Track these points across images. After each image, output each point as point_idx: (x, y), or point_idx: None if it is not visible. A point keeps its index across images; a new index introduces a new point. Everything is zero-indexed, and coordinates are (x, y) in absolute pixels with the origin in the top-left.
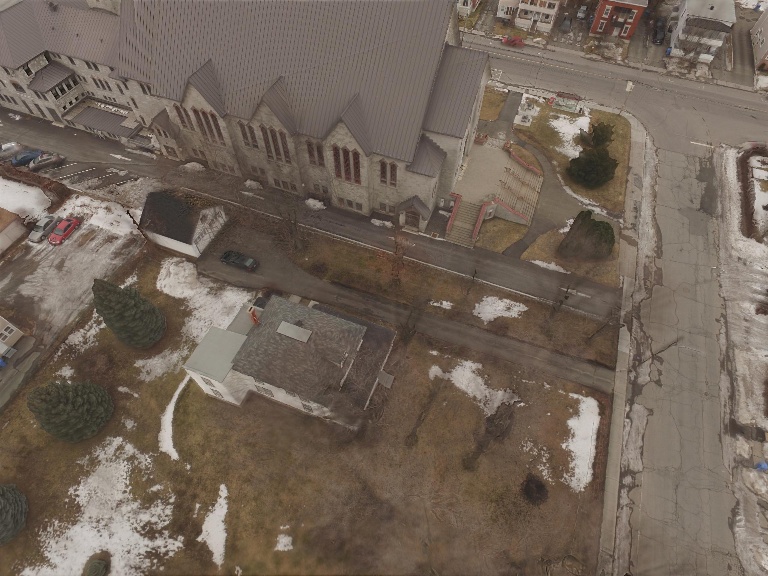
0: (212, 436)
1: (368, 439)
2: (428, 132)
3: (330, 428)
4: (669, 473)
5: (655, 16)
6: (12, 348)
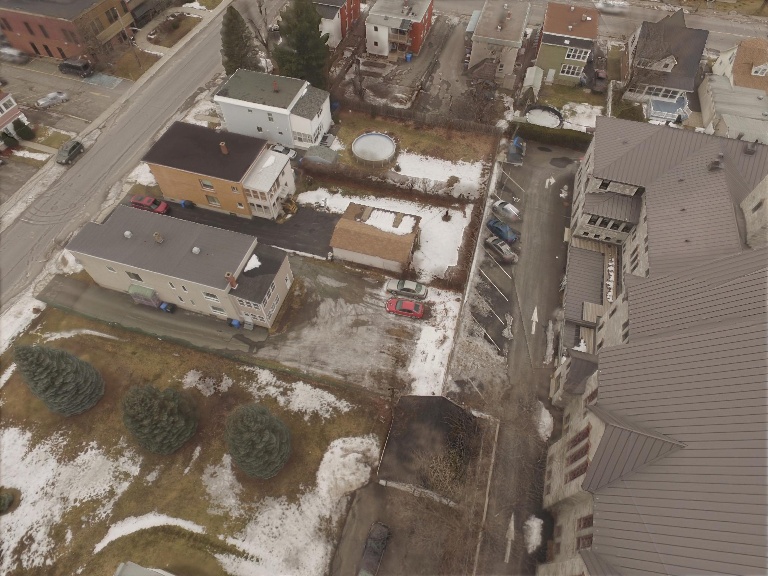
0: None
1: None
2: None
3: None
4: None
5: None
6: (253, 326)
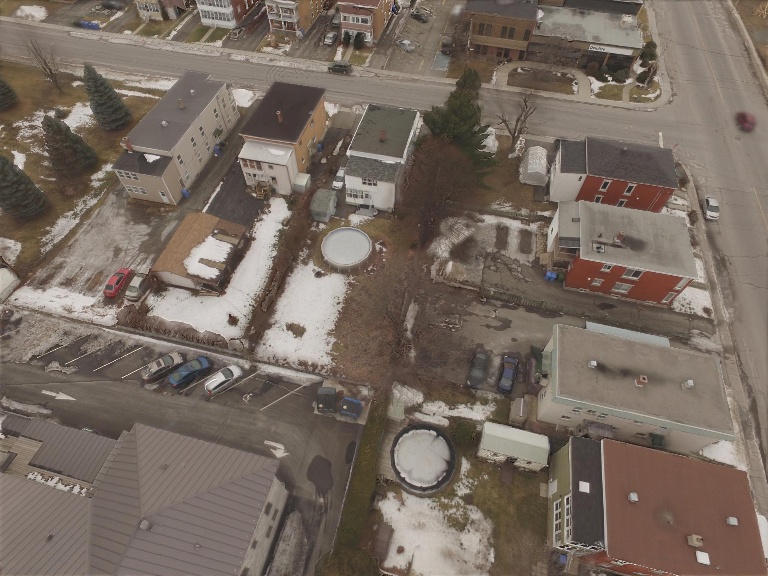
0: None
1: None
2: None
3: None
4: None
5: None
6: None
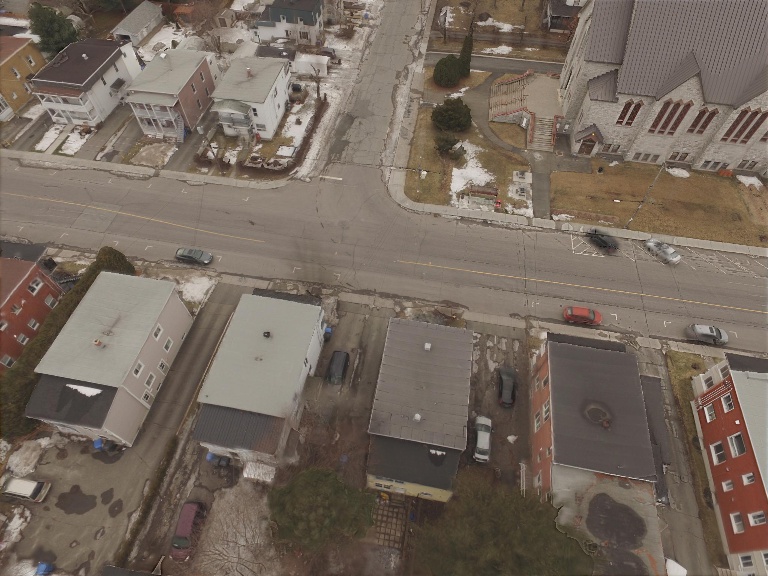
0: None
1: None
2: None
3: None
4: None
5: None
6: None
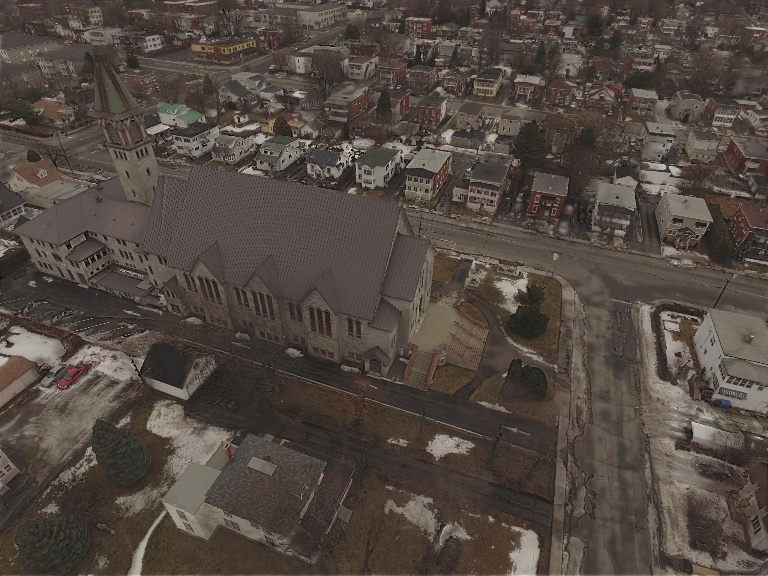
0: (179, 572)
1: (324, 573)
2: (385, 296)
3: (290, 563)
4: None
5: (578, 200)
6: (6, 486)
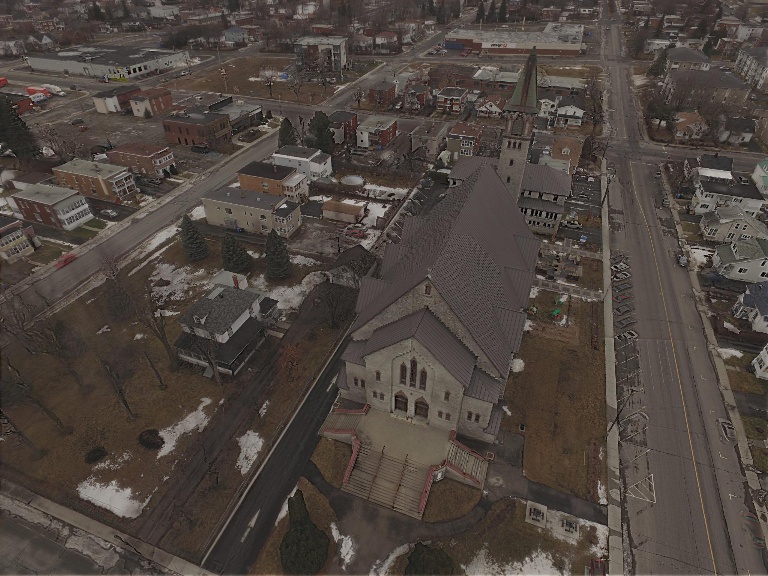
0: None
1: None
2: None
3: None
4: (50, 570)
5: None
6: None
